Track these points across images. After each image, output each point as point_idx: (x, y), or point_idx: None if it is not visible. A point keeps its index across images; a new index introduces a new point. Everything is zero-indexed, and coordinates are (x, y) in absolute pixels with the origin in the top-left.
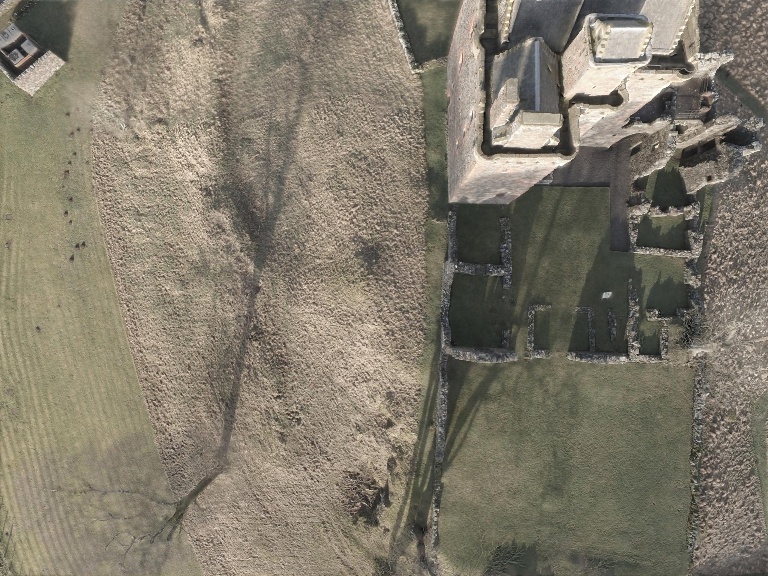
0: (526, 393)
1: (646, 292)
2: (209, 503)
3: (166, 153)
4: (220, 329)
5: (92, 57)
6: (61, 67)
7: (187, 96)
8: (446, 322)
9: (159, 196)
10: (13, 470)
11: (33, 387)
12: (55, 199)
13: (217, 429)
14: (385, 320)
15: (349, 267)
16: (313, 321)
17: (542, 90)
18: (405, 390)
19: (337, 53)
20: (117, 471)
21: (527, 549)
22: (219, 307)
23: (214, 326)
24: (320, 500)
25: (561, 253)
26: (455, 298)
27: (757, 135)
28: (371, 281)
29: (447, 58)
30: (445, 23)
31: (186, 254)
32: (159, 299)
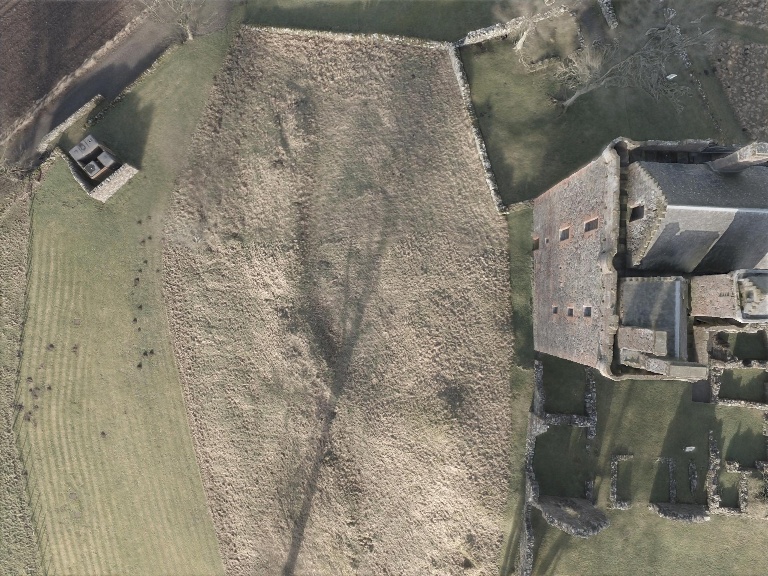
0: (606, 541)
1: (726, 443)
2: None
3: (240, 268)
4: (291, 447)
5: (166, 166)
6: (134, 175)
7: (264, 215)
8: (531, 472)
9: (231, 310)
10: (74, 573)
11: (96, 492)
12: (124, 306)
13: (284, 545)
14: (468, 464)
15: (431, 406)
16: (391, 453)
17: (680, 327)
18: (487, 535)
19: (422, 188)
20: None
21: None
22: (291, 426)
23: (284, 443)
24: None
25: (644, 403)
26: (539, 446)
27: None
28: (455, 424)
29: (534, 201)
30: (531, 164)
31: (257, 370)
32: (228, 412)
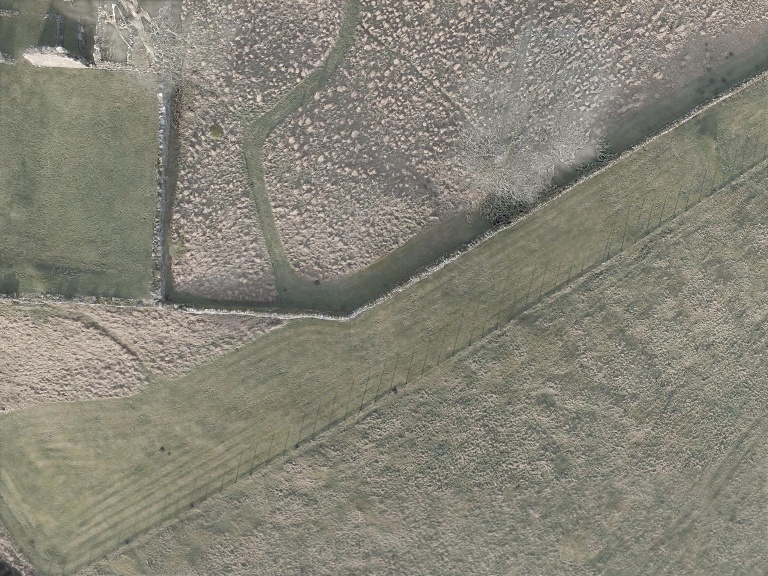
0: None
1: None
2: None
3: None
4: None
5: None
6: None
7: None
8: None
9: None
10: None
11: None
12: None
13: None
14: None
15: None
16: None
17: None
18: None
19: None
20: None
21: None
22: None
23: None
24: None
25: None
26: None
27: None
28: None
29: None
30: None
31: None
32: None
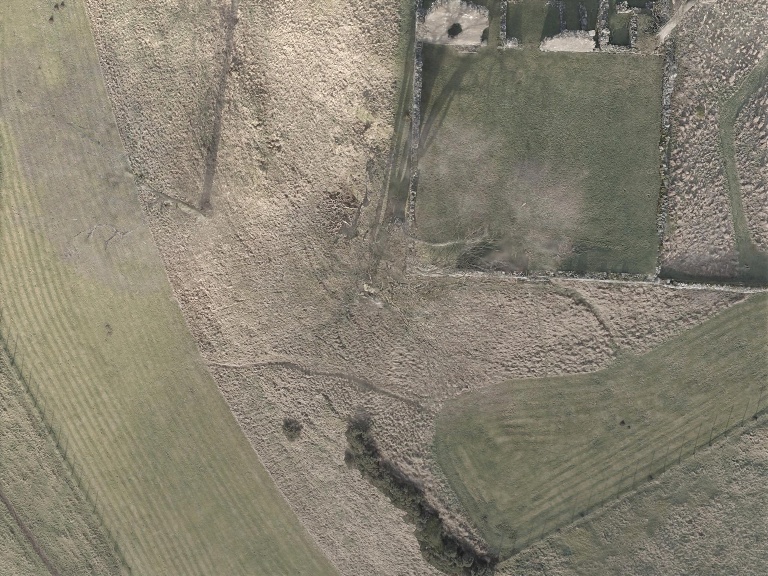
0: (500, 85)
1: None
2: (193, 254)
3: None
4: (200, 73)
5: None
6: None
7: None
8: None
9: None
10: None
11: (16, 151)
12: None
13: (199, 176)
14: (361, 19)
15: None
16: (291, 40)
17: None
18: (381, 85)
19: None
20: (102, 231)
21: (502, 236)
22: (199, 49)
23: (194, 72)
24: (302, 227)
25: None
26: None
27: None
28: None
29: None
30: None
31: (165, 3)
32: (139, 52)
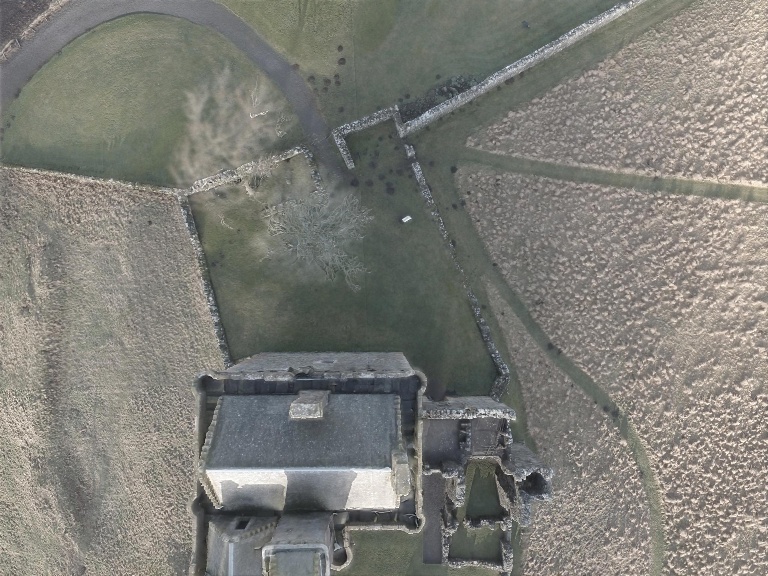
0: None
1: None
2: None
3: None
4: None
5: None
6: None
7: (17, 361)
8: None
9: None
10: None
11: None
12: None
13: None
14: None
15: (162, 571)
16: None
17: None
18: None
19: (155, 341)
20: None
21: None
22: None
23: None
24: None
25: (372, 567)
26: None
27: (548, 485)
28: None
29: None
30: (263, 315)
31: (21, 516)
32: None
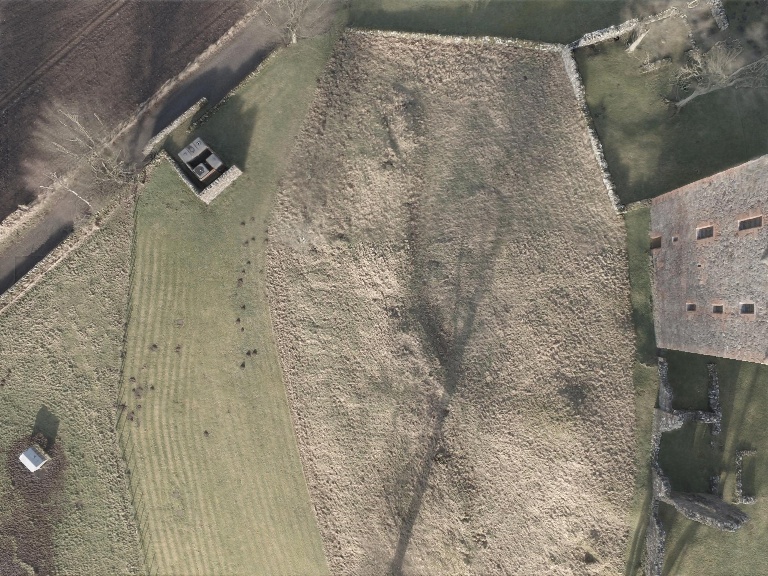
0: (730, 536)
1: None
2: None
3: (346, 269)
4: (399, 445)
5: (269, 168)
6: (238, 177)
7: (373, 216)
8: (658, 468)
9: (337, 310)
10: (176, 571)
11: (199, 490)
12: (227, 306)
13: (391, 542)
14: (592, 460)
15: (551, 403)
16: (507, 450)
17: None
18: (612, 530)
19: (537, 188)
20: (283, 575)
21: None
22: (400, 424)
23: (392, 441)
24: None
25: (766, 399)
26: (664, 442)
27: None
28: (578, 421)
29: (651, 200)
30: (647, 164)
31: (364, 368)
32: (333, 410)
